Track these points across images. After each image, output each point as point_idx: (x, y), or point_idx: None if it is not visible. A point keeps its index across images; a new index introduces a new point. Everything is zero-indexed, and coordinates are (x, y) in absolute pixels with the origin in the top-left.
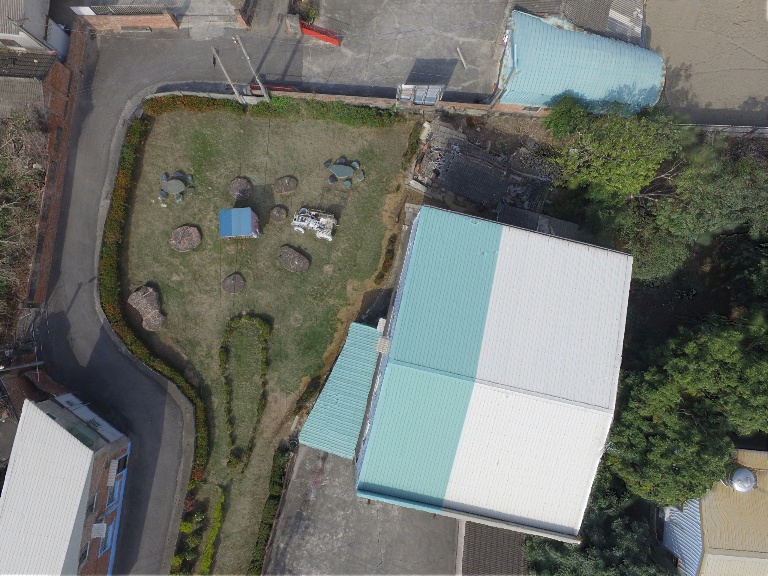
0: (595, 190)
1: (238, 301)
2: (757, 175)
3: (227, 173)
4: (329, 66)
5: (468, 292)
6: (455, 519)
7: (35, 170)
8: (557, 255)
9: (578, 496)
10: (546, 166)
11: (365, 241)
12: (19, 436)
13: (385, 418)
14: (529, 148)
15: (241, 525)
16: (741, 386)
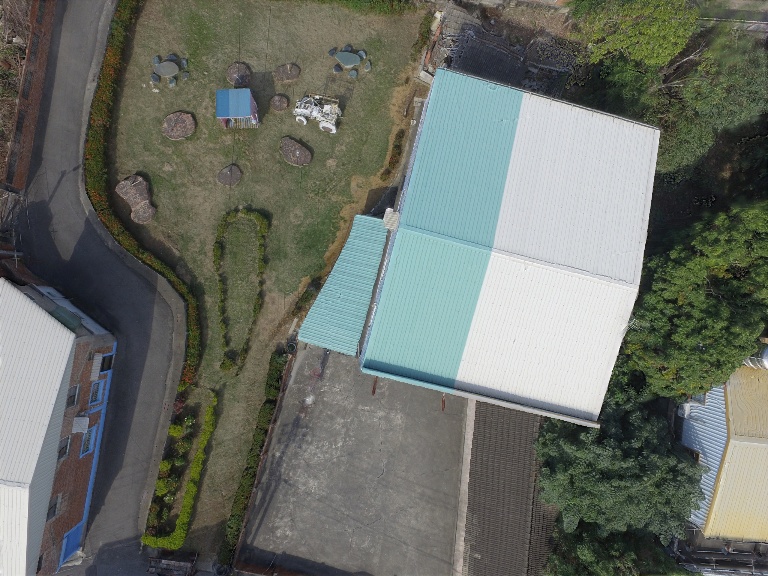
0: (617, 75)
1: (234, 195)
2: None
3: (224, 58)
4: None
5: (485, 159)
6: (461, 429)
7: (15, 44)
8: (580, 125)
9: (598, 379)
10: (564, 57)
11: (371, 136)
12: None
13: (394, 289)
14: None
15: (234, 432)
16: None
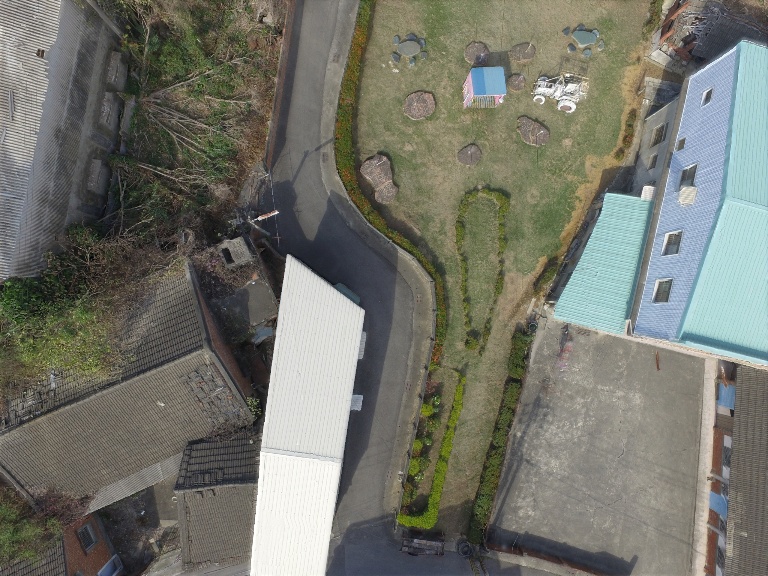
0: None
1: (473, 174)
2: None
3: (462, 37)
4: None
5: None
6: (697, 409)
7: (266, 23)
8: None
9: None
10: None
11: (604, 115)
12: (285, 292)
13: (717, 262)
14: None
15: (476, 412)
16: None
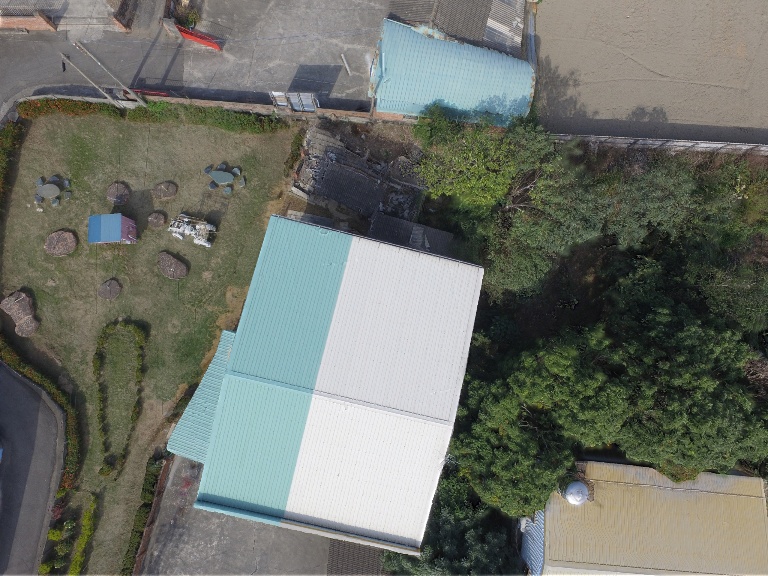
0: (464, 200)
1: (114, 307)
2: (637, 186)
3: (105, 178)
4: (210, 71)
5: (313, 303)
6: None
7: None
8: (407, 266)
9: (420, 508)
10: (424, 175)
11: (246, 248)
12: None
13: (223, 429)
14: (411, 156)
15: (114, 533)
16: (571, 400)
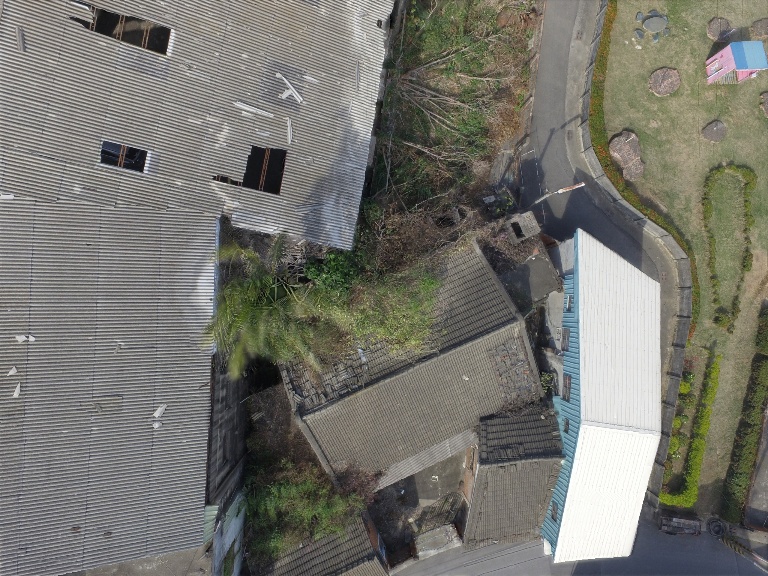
0: None
1: (717, 151)
2: None
3: (703, 14)
4: None
5: None
6: None
7: None
8: None
9: None
10: None
11: None
12: (582, 266)
13: None
14: None
15: (725, 390)
16: None
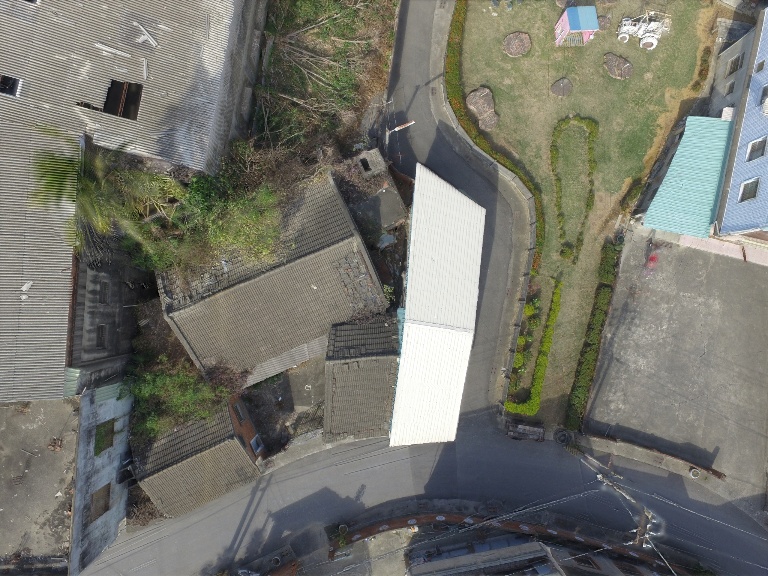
0: None
1: (565, 105)
2: None
3: None
4: None
5: None
6: None
7: None
8: None
9: None
10: None
11: (681, 52)
12: (417, 193)
13: None
14: None
15: (570, 315)
16: None
